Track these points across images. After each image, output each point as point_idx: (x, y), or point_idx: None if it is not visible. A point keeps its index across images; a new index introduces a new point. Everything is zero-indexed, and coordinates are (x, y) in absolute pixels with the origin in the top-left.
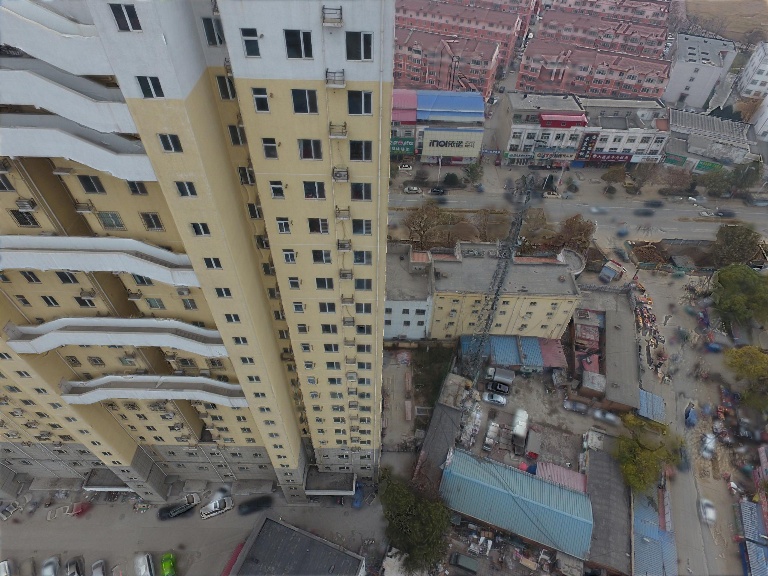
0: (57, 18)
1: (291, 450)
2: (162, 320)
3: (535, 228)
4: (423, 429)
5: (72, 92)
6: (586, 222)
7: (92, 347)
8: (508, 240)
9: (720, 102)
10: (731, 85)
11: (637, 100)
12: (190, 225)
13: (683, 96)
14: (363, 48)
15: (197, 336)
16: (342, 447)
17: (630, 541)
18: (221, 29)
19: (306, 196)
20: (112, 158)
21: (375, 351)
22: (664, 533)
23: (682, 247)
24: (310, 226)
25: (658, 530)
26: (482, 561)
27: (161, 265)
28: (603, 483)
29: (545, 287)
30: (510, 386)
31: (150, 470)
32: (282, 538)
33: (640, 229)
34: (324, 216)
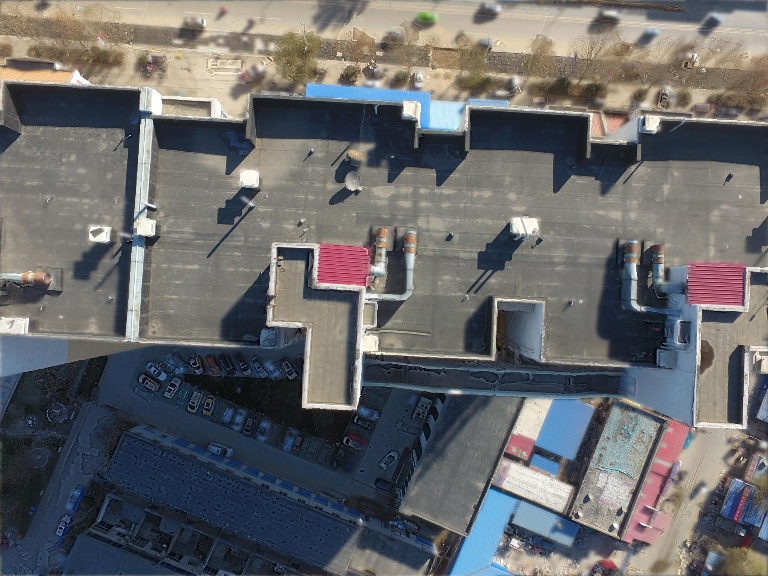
0: None
1: None
2: None
3: (720, 63)
4: None
5: None
6: None
7: None
8: None
9: None
10: None
11: None
12: None
13: None
14: None
15: None
16: None
17: None
18: None
19: None
20: None
21: None
22: None
23: None
24: None
25: None
26: None
27: None
28: None
29: None
30: None
31: None
32: None
33: None
34: None
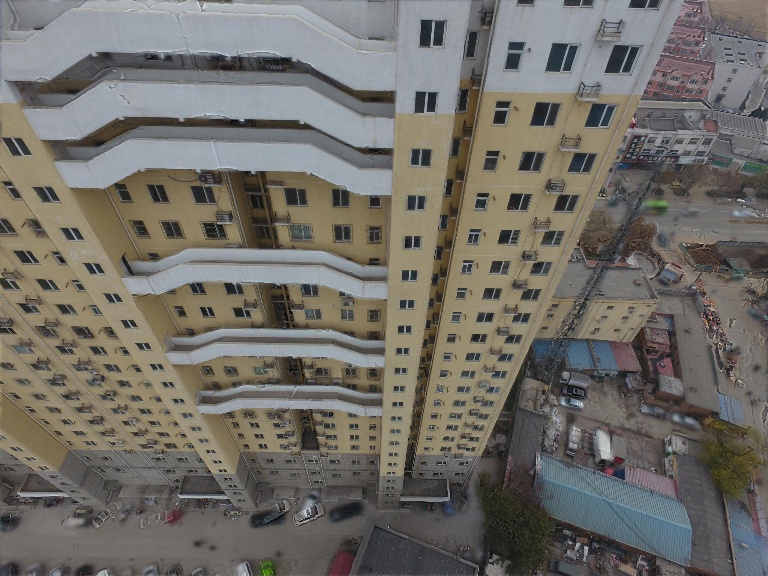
0: (341, 33)
1: (405, 458)
2: (321, 331)
3: None
4: (504, 434)
5: (343, 107)
6: (648, 225)
7: (233, 357)
8: (610, 245)
9: (755, 103)
10: (764, 85)
11: (683, 101)
12: (403, 238)
13: (720, 97)
14: (625, 61)
15: (351, 346)
16: (446, 454)
17: (730, 547)
18: (486, 43)
19: (507, 208)
20: (355, 172)
21: (517, 360)
22: (760, 538)
23: (736, 249)
24: (500, 237)
25: (754, 535)
26: (580, 567)
27: (354, 277)
28: (695, 488)
29: (622, 291)
30: (585, 390)
31: (247, 477)
32: (392, 546)
33: (692, 231)
34: (518, 227)
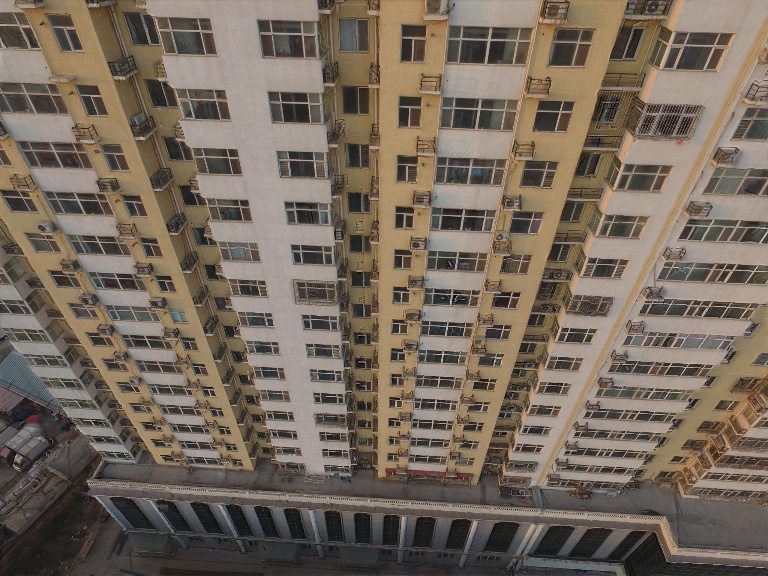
0: None
1: None
2: None
3: None
4: None
5: None
6: None
7: None
8: None
9: None
10: None
11: None
12: None
13: None
14: None
15: None
16: None
17: None
18: None
19: None
20: None
21: None
22: None
23: None
24: None
25: None
26: None
27: None
28: None
29: None
30: None
31: None
32: None
33: None
34: None
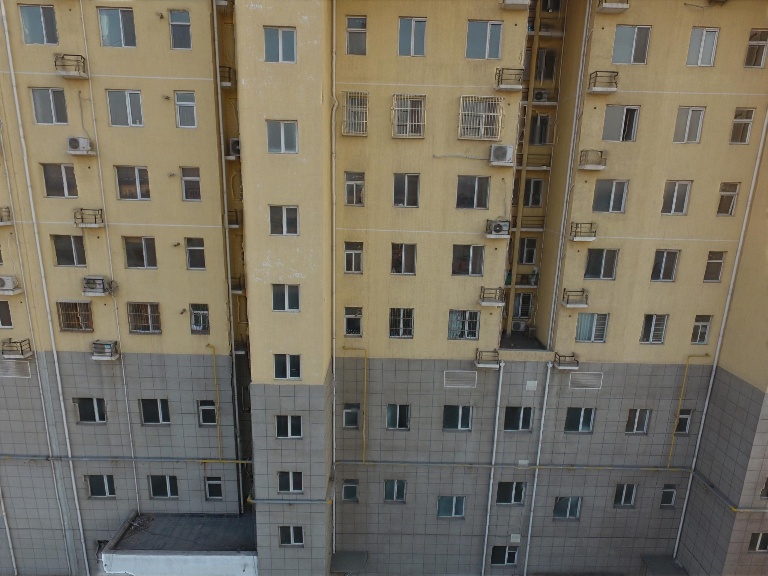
0: None
1: None
2: None
3: None
4: None
5: None
6: None
7: None
8: None
9: None
10: None
11: None
12: None
13: None
14: None
15: None
16: None
17: None
18: None
19: None
20: None
21: None
22: None
23: None
24: None
25: None
26: None
27: None
28: None
29: None
30: None
31: None
32: None
33: None
34: None
